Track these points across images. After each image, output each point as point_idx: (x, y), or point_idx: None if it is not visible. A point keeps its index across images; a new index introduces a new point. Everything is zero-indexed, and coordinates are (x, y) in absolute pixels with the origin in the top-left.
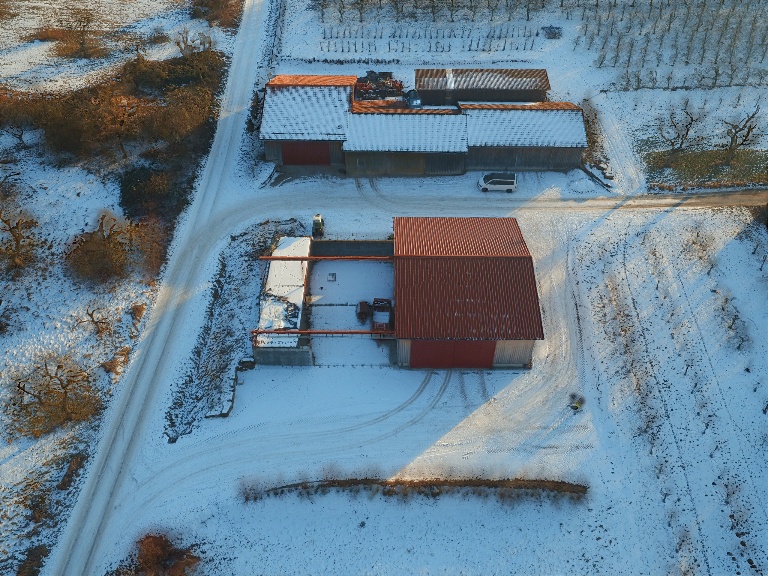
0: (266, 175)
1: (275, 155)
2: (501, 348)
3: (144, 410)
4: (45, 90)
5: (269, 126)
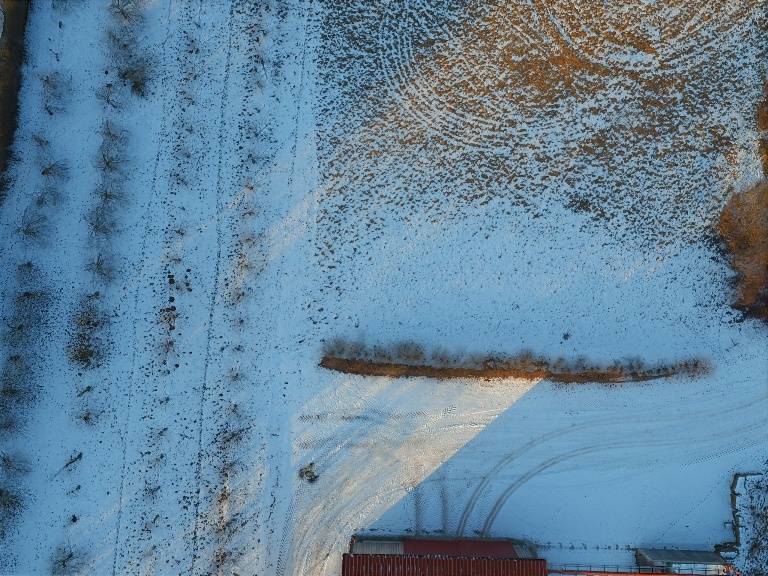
0: None
1: None
2: None
3: None
4: None
5: None
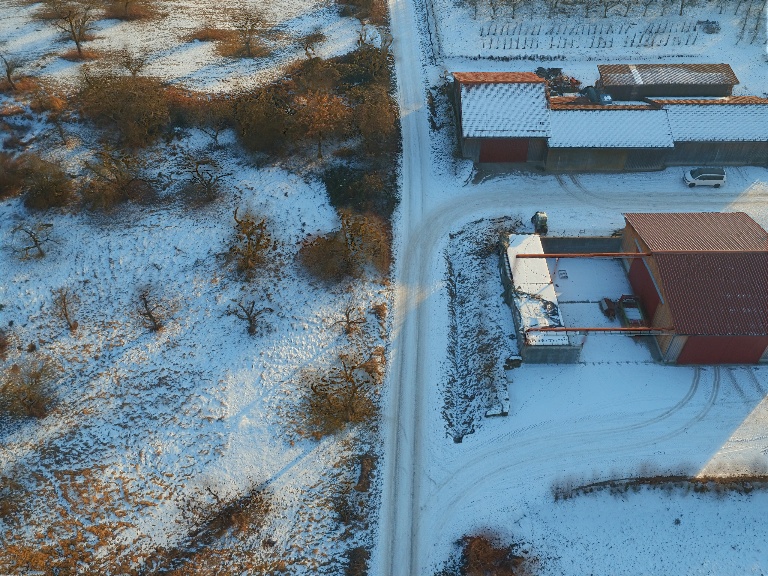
0: (467, 173)
1: (473, 153)
2: None
3: (418, 410)
4: (221, 90)
5: (471, 123)
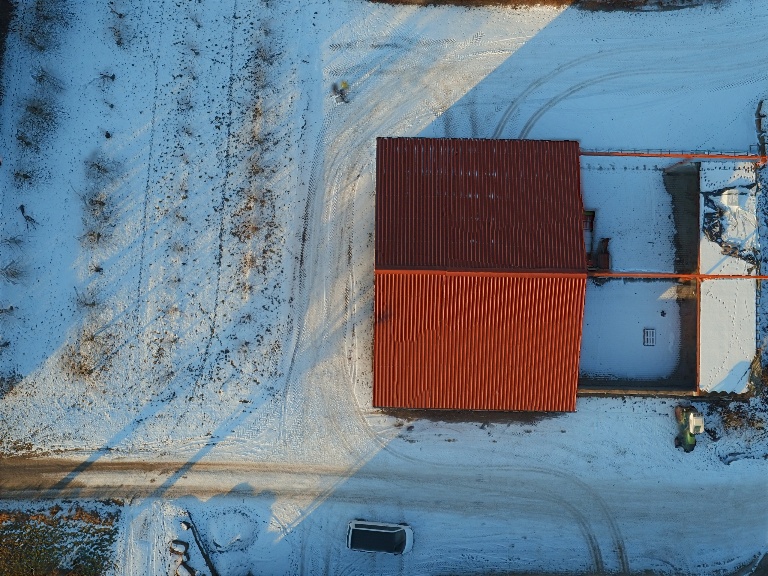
0: None
1: None
2: None
3: None
4: None
5: None
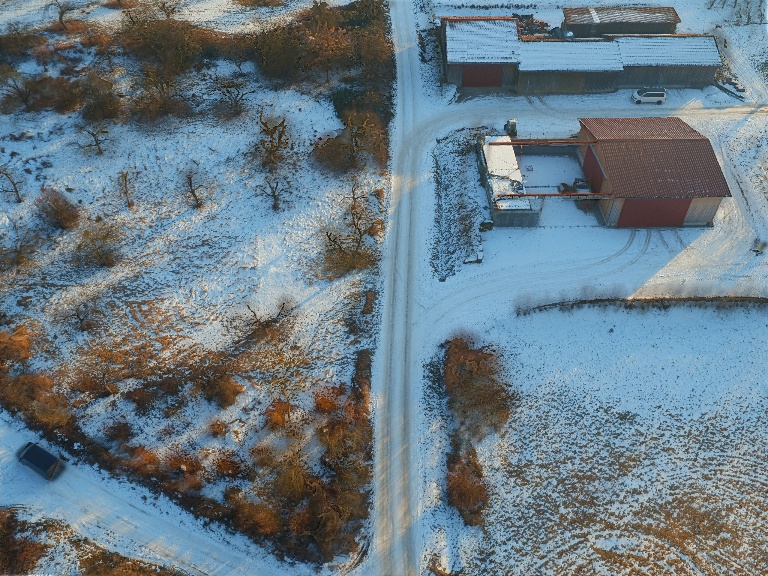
0: (452, 94)
1: (456, 78)
2: (693, 207)
3: (411, 261)
4: (242, 31)
5: (454, 52)
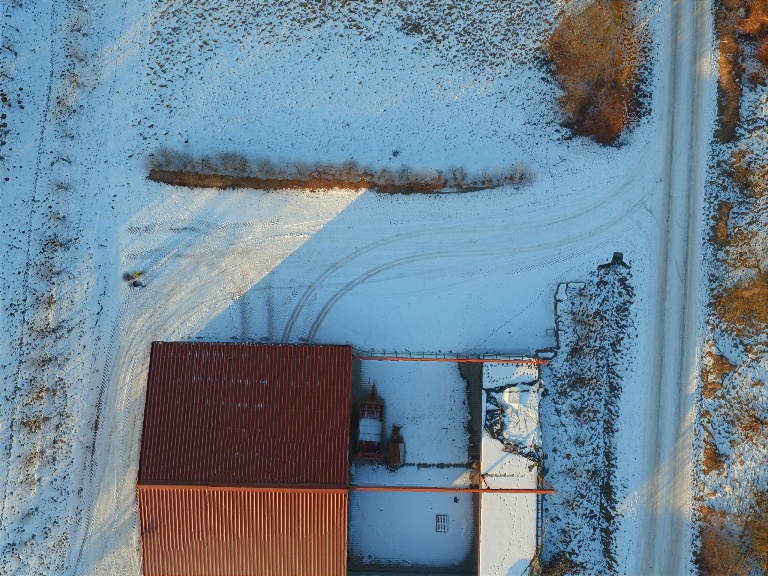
0: None
1: None
2: None
3: (662, 301)
4: None
5: None
